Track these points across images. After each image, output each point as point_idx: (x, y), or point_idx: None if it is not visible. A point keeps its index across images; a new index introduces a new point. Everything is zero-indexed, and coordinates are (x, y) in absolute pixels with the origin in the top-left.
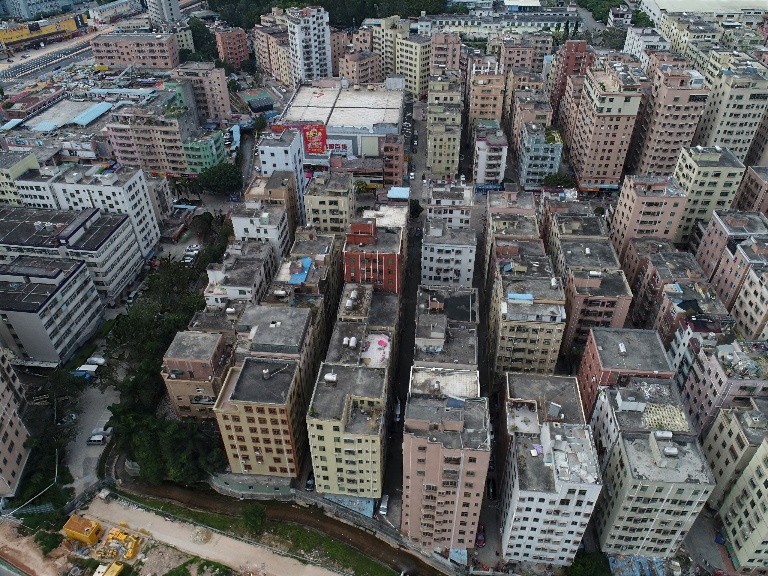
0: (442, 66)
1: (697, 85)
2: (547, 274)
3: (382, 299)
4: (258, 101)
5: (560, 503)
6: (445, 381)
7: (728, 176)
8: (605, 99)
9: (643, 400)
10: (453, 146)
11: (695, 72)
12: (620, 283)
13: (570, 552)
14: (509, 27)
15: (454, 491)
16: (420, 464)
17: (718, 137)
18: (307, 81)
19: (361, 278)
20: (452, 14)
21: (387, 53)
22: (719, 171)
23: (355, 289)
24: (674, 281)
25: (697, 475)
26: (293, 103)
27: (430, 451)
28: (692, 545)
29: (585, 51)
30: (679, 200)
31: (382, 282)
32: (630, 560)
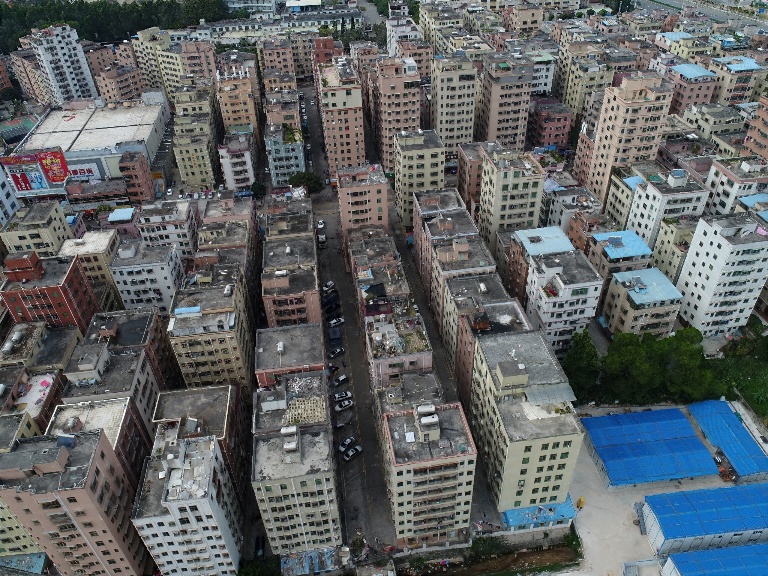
0: (190, 76)
1: (411, 72)
2: (232, 281)
3: (59, 335)
4: (10, 131)
5: (181, 523)
6: (92, 415)
7: (432, 157)
8: (327, 94)
9: (282, 398)
10: (202, 157)
11: (410, 60)
12: (311, 278)
13: (227, 565)
14: (290, 28)
15: (78, 533)
16: (30, 514)
17: (443, 119)
18: (57, 105)
19: (32, 316)
20: (233, 20)
21: (152, 66)
22: (422, 153)
23: (23, 329)
24: (370, 267)
25: (320, 464)
26: (37, 130)
27: (26, 500)
28: (370, 526)
29: (334, 47)
30: (380, 187)
31: (56, 317)
32: (301, 556)
